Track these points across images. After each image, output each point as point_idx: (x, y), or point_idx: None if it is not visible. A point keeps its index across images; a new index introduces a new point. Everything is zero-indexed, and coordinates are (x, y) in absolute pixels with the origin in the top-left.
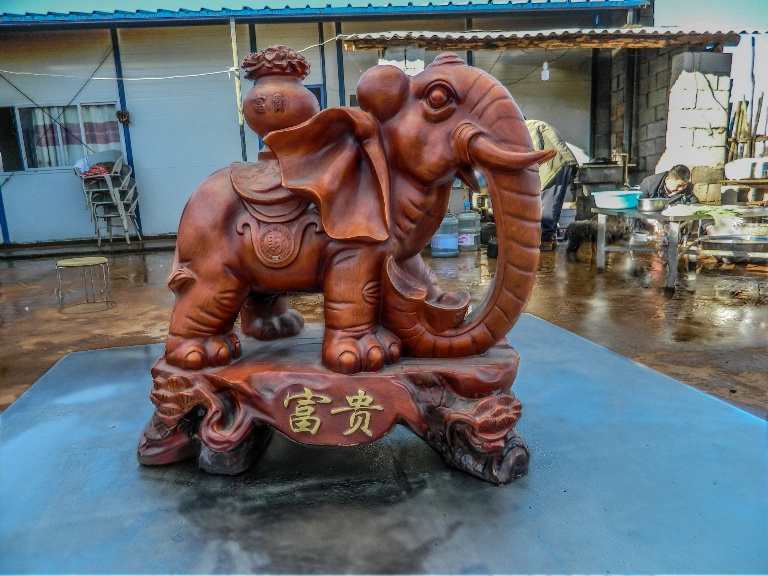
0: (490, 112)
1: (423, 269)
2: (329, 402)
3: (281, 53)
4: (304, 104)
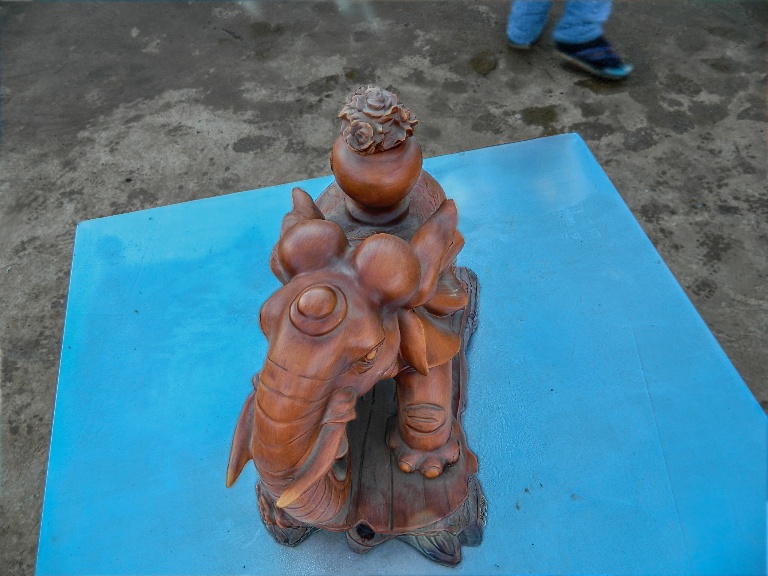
0: None
1: (409, 407)
2: None
3: None
4: (344, 183)
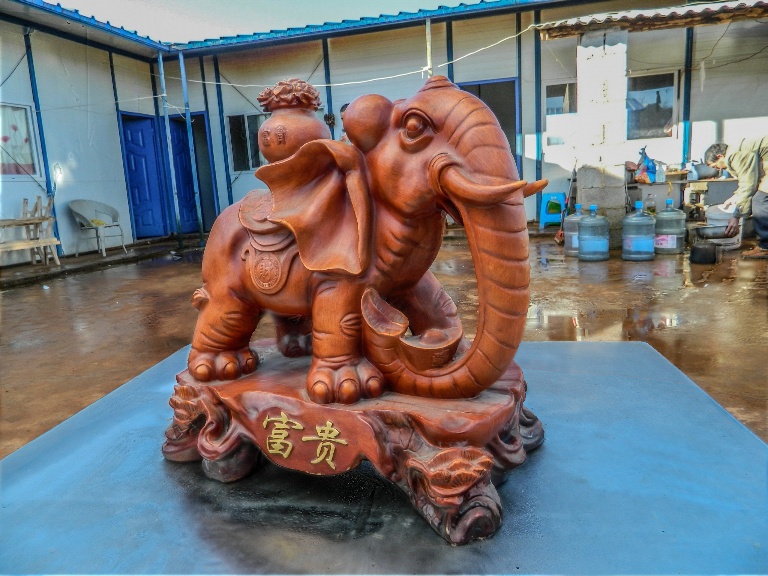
0: (465, 141)
1: (437, 299)
2: (301, 429)
3: (291, 86)
4: (306, 135)
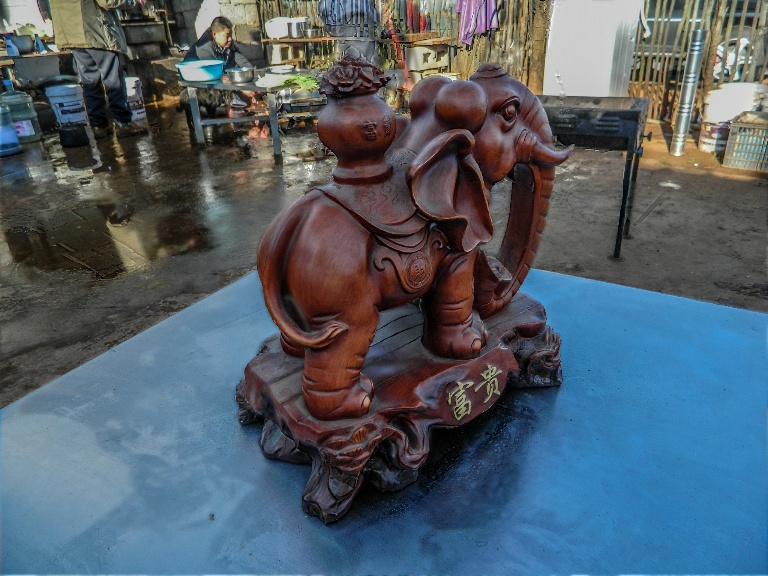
0: (538, 119)
1: None
2: (473, 384)
3: None
4: None
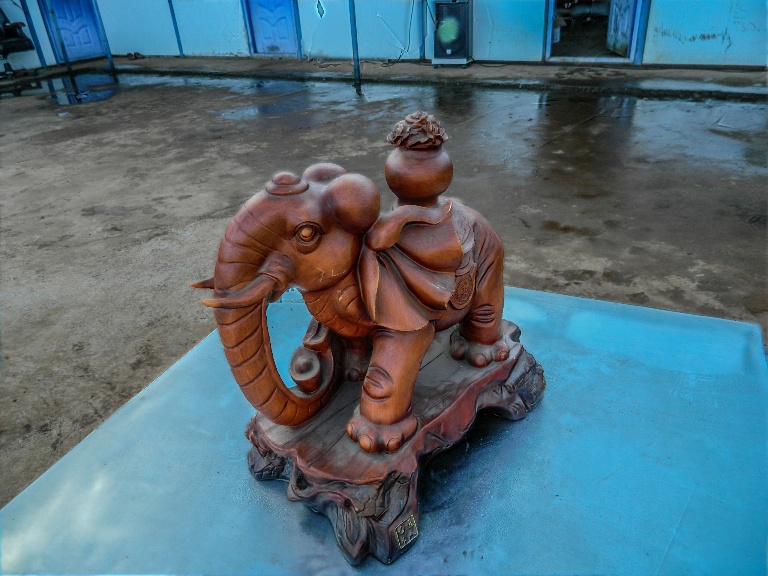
0: None
1: (369, 369)
2: None
3: None
4: None
